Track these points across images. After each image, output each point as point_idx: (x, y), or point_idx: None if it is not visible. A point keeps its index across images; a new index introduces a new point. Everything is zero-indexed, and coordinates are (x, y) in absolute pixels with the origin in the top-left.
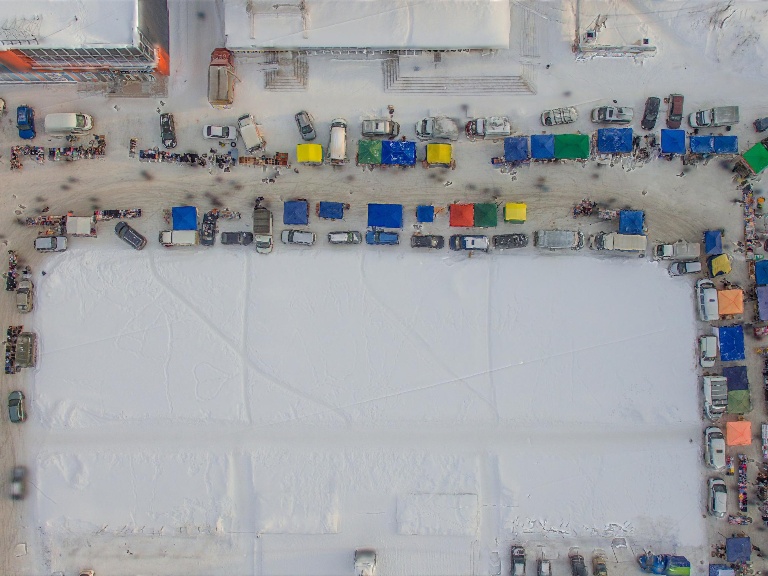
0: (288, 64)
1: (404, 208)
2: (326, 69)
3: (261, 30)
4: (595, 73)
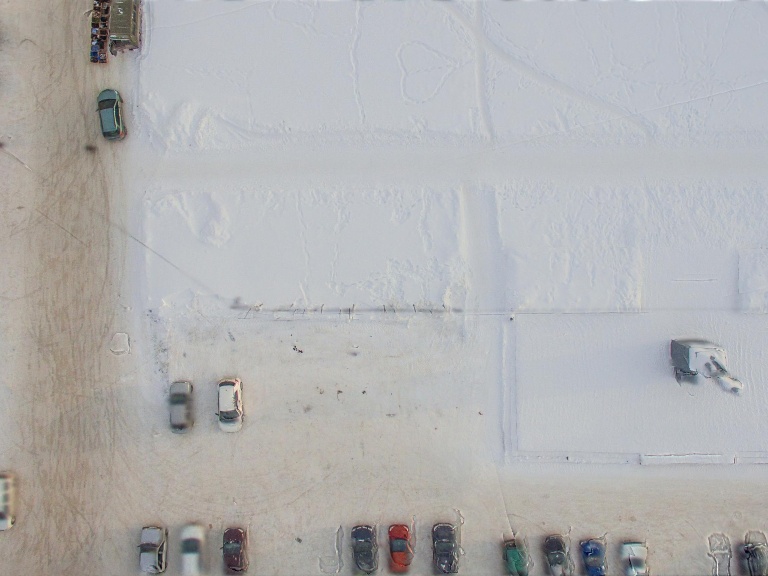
0: None
1: None
2: None
3: None
4: None
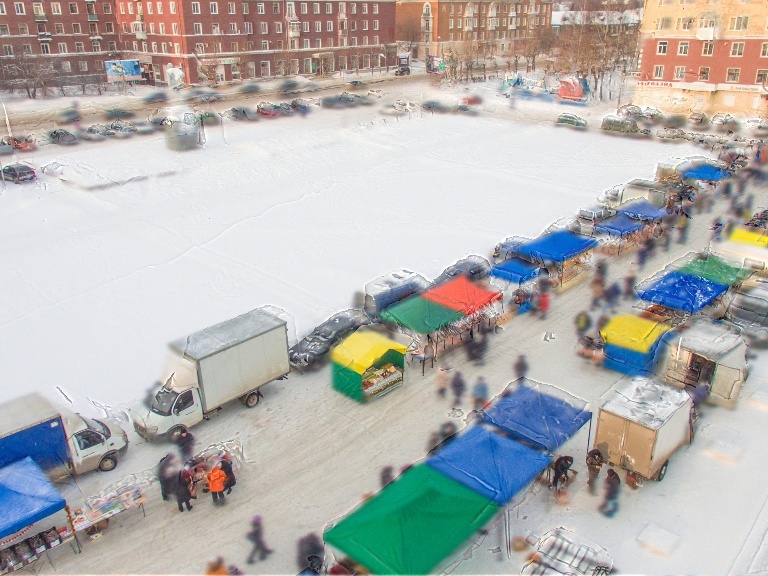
0: None
1: (553, 287)
2: None
3: None
4: None
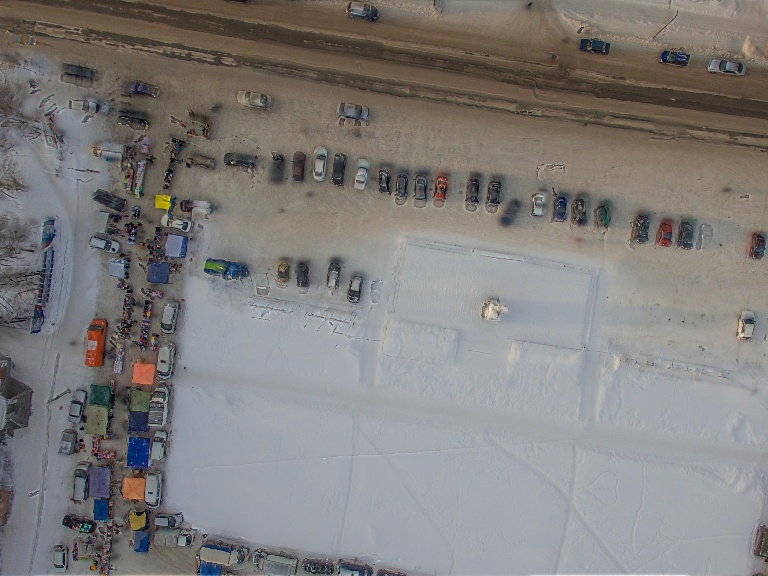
0: None
1: None
2: None
3: None
4: None
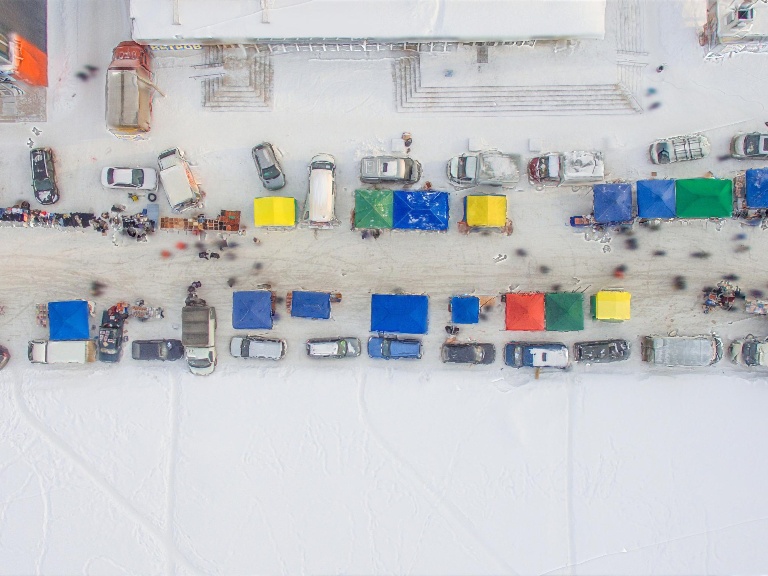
0: (240, 67)
1: (429, 298)
2: (302, 75)
3: (190, 10)
4: (735, 79)
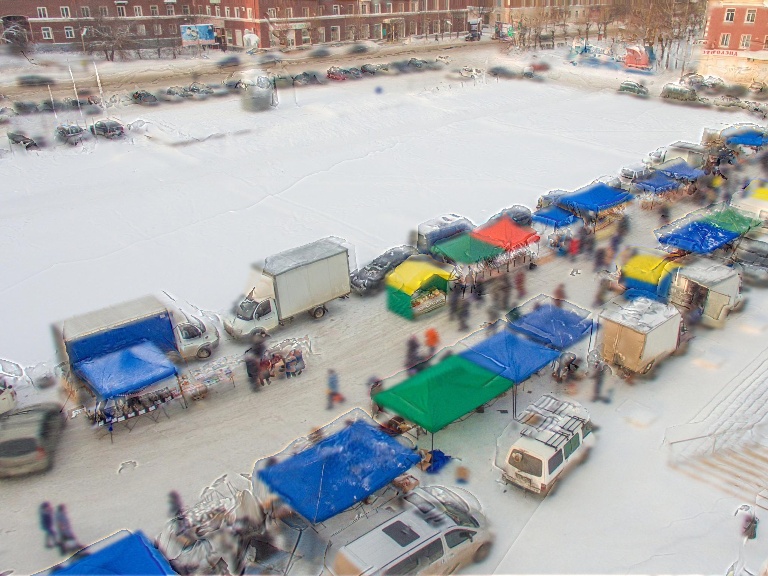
0: None
1: (586, 234)
2: None
3: None
4: None
